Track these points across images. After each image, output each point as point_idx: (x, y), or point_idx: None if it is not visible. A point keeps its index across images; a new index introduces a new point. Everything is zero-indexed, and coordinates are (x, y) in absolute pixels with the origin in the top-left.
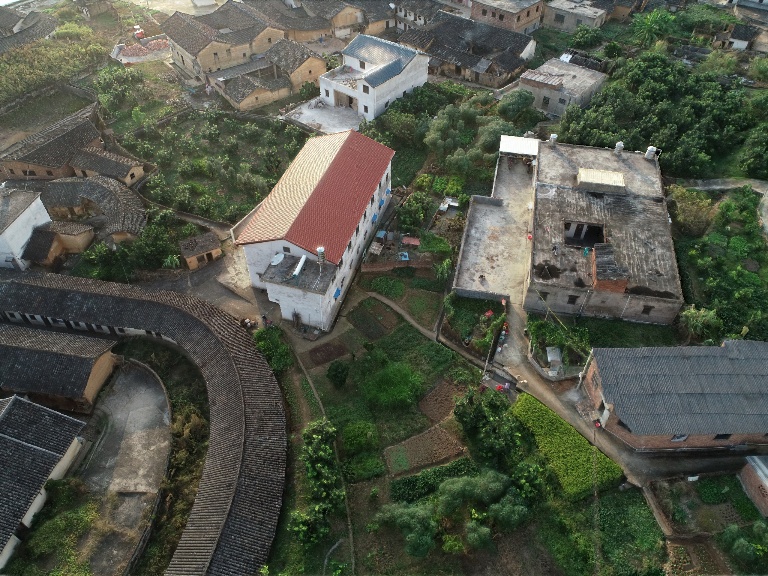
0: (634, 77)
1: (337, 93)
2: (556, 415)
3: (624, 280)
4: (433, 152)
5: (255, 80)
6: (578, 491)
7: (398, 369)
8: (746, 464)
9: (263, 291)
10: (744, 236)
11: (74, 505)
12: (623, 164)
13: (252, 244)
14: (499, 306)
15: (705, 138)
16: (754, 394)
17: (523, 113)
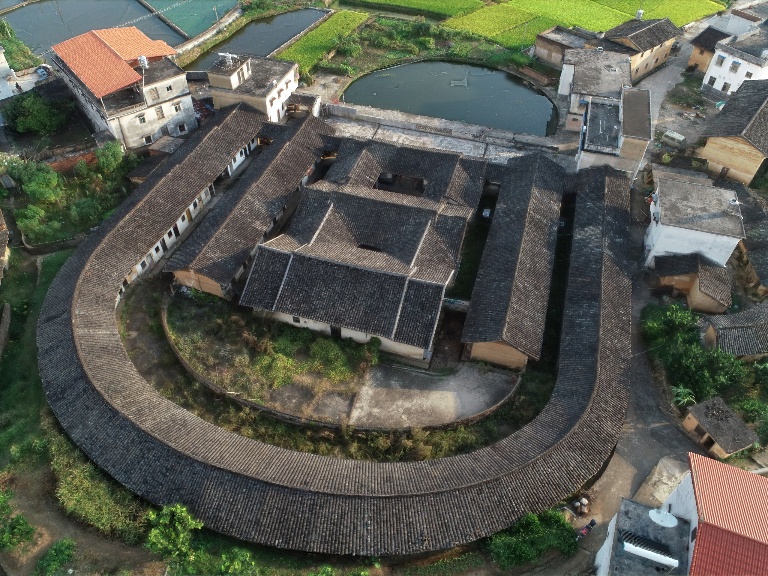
0: None
1: None
2: None
3: None
4: None
5: None
6: None
7: None
8: None
9: None
10: None
11: (353, 363)
12: None
13: None
14: None
15: None
16: None
17: None
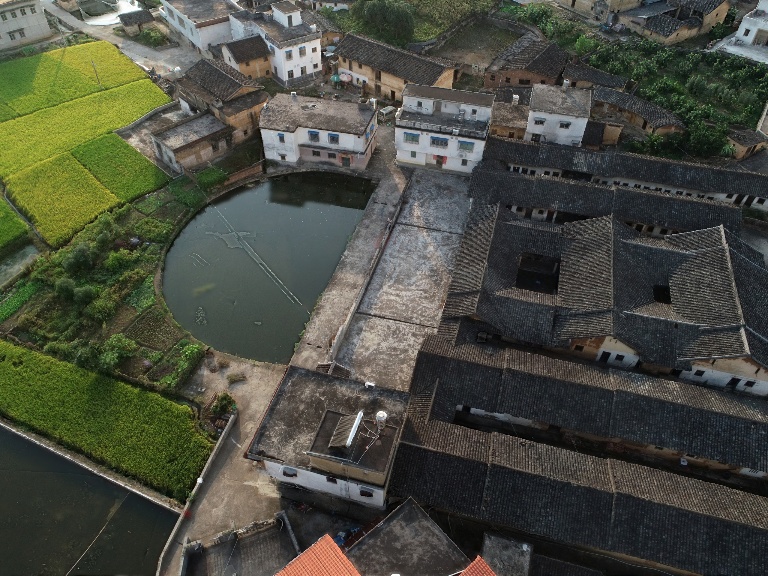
0: None
1: (758, 32)
2: None
3: None
4: None
5: None
6: None
7: None
8: None
9: None
10: None
11: None
12: None
13: None
14: None
15: None
16: None
17: None
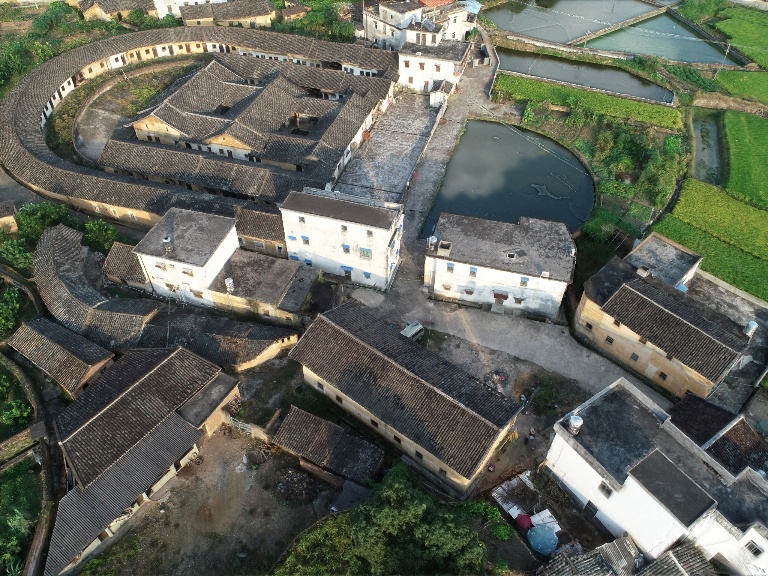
0: None
1: None
2: None
3: None
4: None
5: None
6: None
7: None
8: None
9: None
10: None
11: None
12: None
13: None
14: None
15: None
16: None
17: None
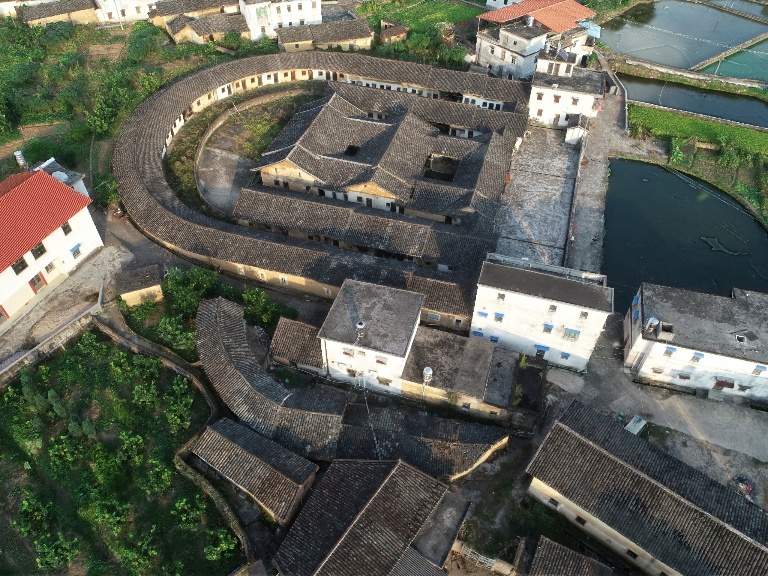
0: None
1: None
2: None
3: None
4: None
5: None
6: None
7: None
8: None
9: None
10: None
11: None
12: None
13: None
14: None
15: None
16: None
17: None
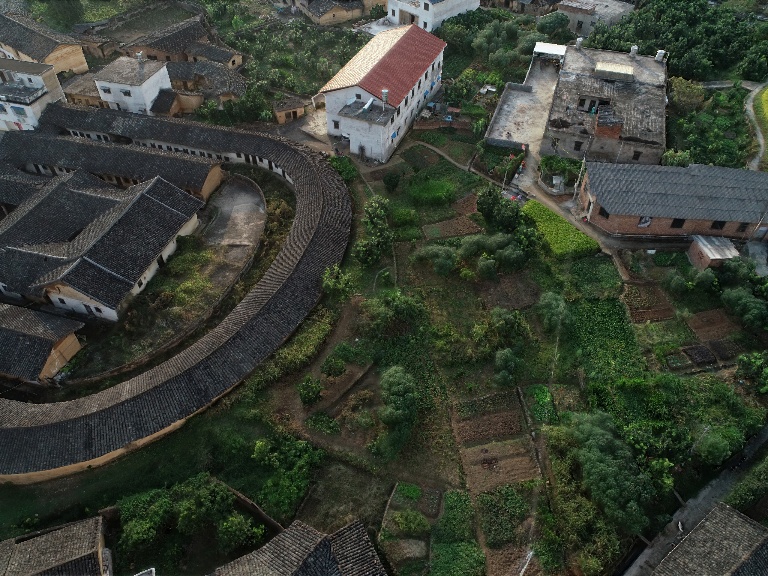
0: (659, 8)
1: (402, 13)
2: (554, 212)
3: (618, 126)
4: (479, 56)
5: (334, 1)
6: (563, 253)
7: (437, 183)
8: (692, 242)
9: (336, 137)
10: (728, 116)
11: (197, 251)
12: (636, 63)
13: (332, 92)
14: (520, 152)
15: (711, 51)
16: (705, 197)
17: (559, 33)
